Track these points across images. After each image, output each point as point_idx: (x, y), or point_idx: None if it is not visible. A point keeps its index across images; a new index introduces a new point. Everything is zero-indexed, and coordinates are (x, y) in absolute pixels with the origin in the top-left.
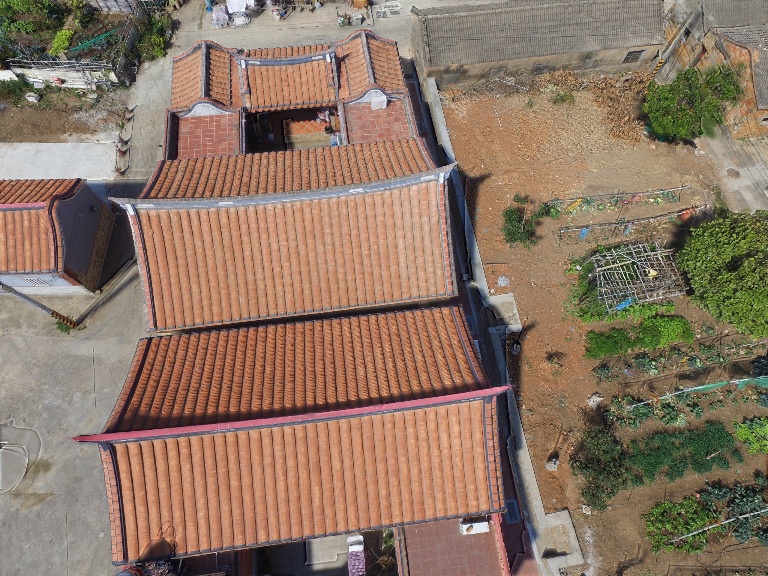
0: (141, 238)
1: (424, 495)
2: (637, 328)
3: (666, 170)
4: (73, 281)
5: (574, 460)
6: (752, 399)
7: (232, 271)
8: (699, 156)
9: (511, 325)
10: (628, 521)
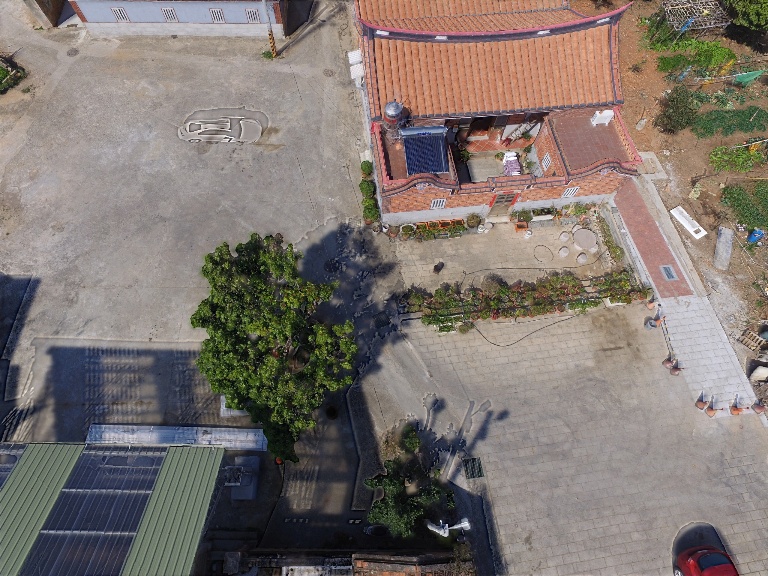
0: None
1: (570, 91)
2: (694, 56)
3: None
4: (279, 17)
5: None
6: None
7: None
8: None
9: None
10: (696, 157)
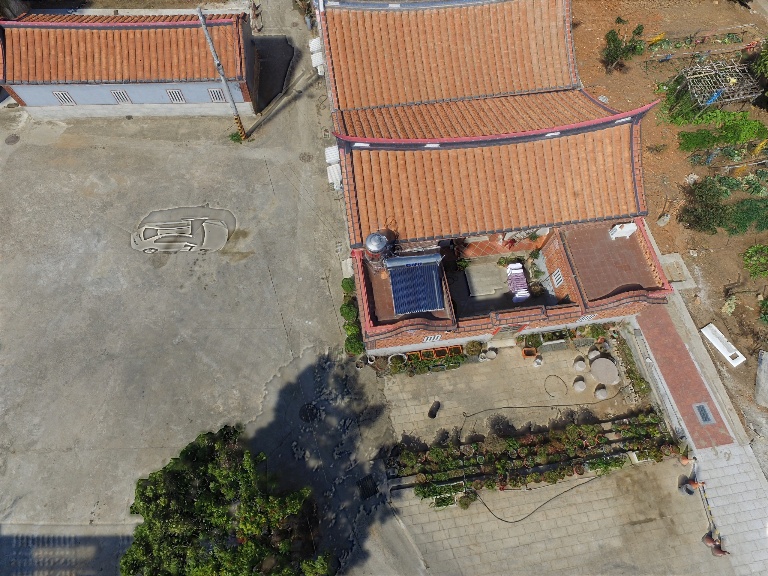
0: (327, 34)
1: (585, 202)
2: (719, 129)
3: (729, 20)
4: (247, 95)
5: (680, 219)
6: None
7: (398, 65)
8: (753, 14)
9: None
10: (728, 259)
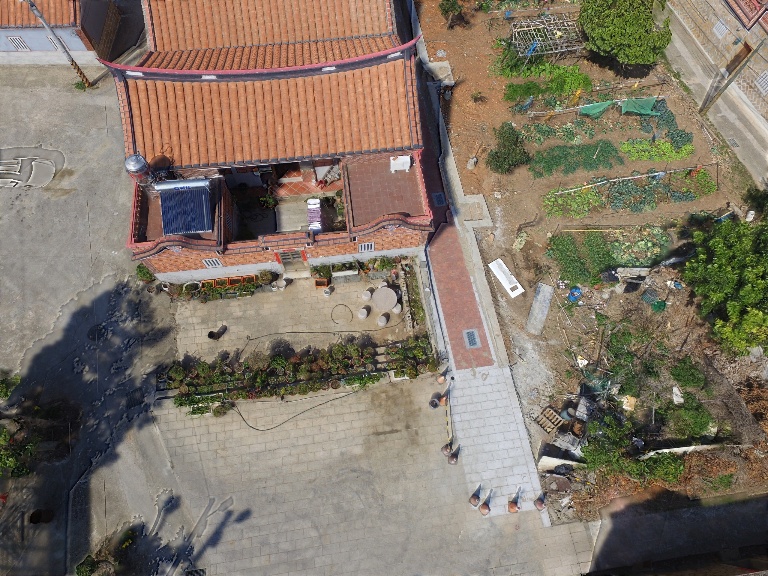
0: None
1: (361, 134)
2: (548, 82)
3: None
4: (88, 43)
5: None
6: (636, 128)
7: (216, 11)
8: None
9: (445, 81)
10: (529, 200)
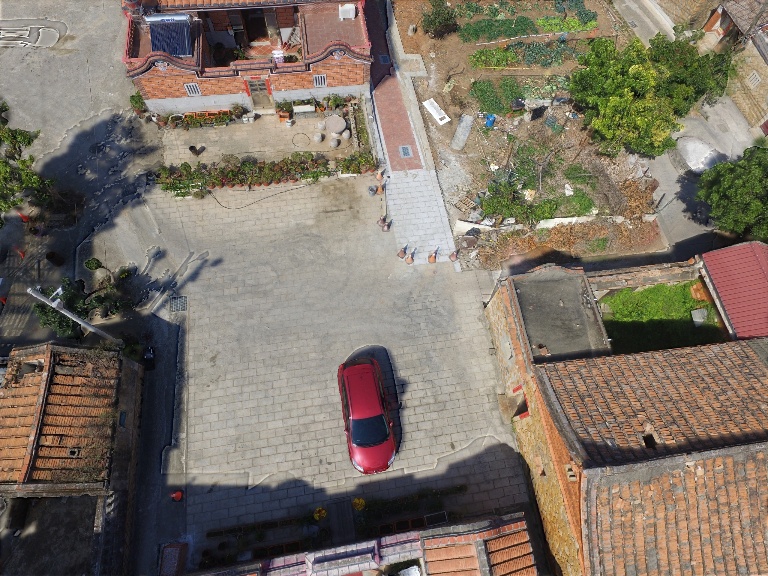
0: None
1: None
2: None
3: None
4: None
5: (427, 31)
6: (551, 9)
7: None
8: None
9: None
10: (459, 58)
